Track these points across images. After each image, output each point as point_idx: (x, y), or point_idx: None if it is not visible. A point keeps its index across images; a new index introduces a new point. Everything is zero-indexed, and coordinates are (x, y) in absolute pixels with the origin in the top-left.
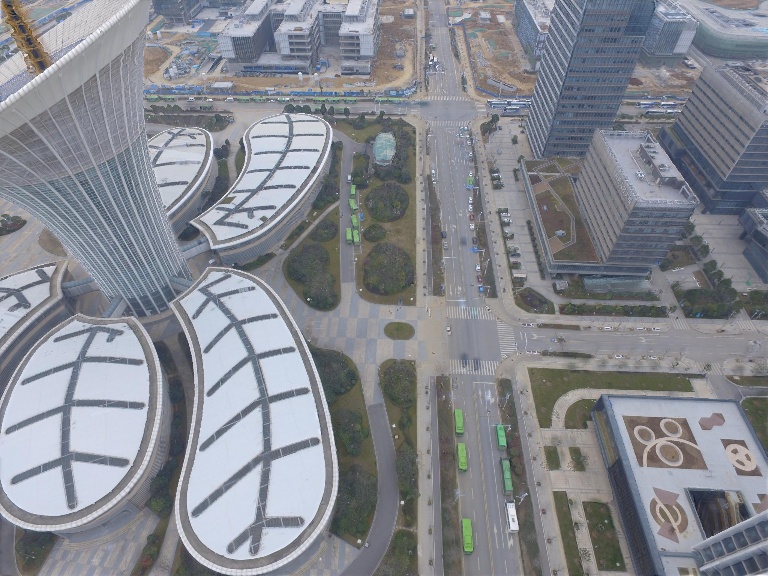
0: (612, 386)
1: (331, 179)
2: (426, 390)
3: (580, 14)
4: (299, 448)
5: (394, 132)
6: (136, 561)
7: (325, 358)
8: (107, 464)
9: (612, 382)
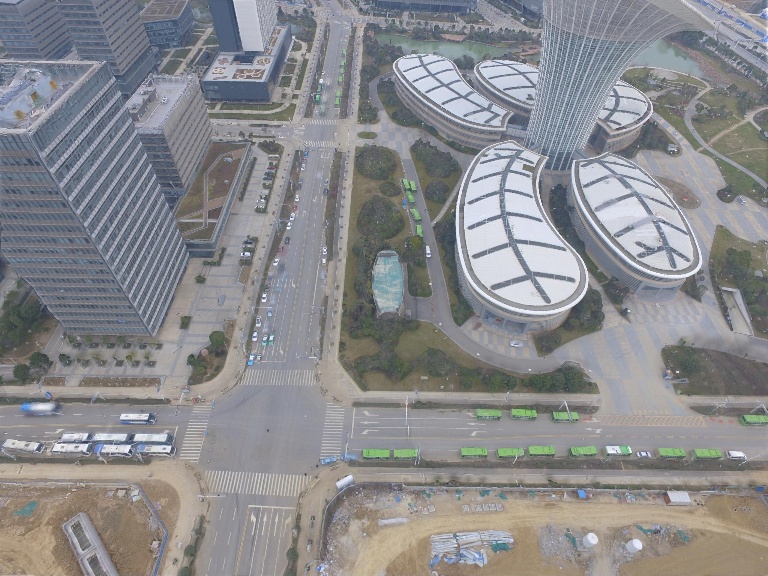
0: (248, 114)
1: (449, 248)
2: (353, 114)
3: (115, 83)
4: (411, 68)
5: (376, 334)
6: (467, 79)
7: (411, 120)
8: (489, 66)
9: (247, 115)
